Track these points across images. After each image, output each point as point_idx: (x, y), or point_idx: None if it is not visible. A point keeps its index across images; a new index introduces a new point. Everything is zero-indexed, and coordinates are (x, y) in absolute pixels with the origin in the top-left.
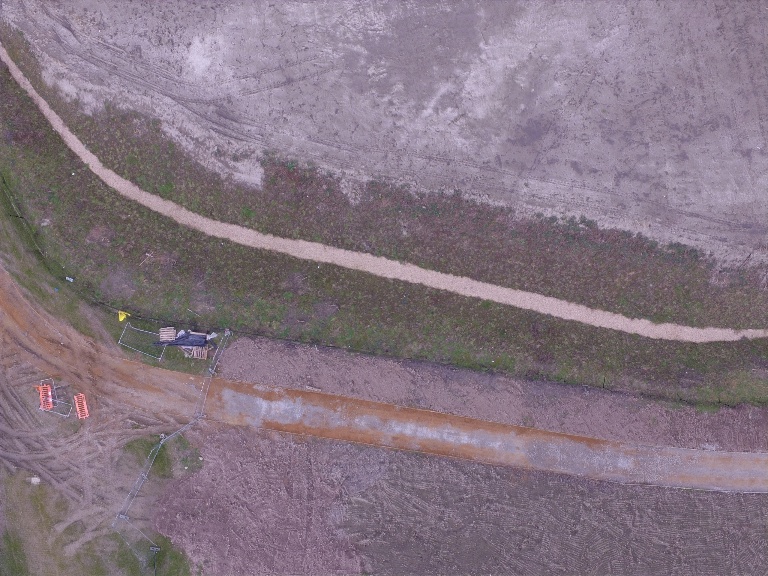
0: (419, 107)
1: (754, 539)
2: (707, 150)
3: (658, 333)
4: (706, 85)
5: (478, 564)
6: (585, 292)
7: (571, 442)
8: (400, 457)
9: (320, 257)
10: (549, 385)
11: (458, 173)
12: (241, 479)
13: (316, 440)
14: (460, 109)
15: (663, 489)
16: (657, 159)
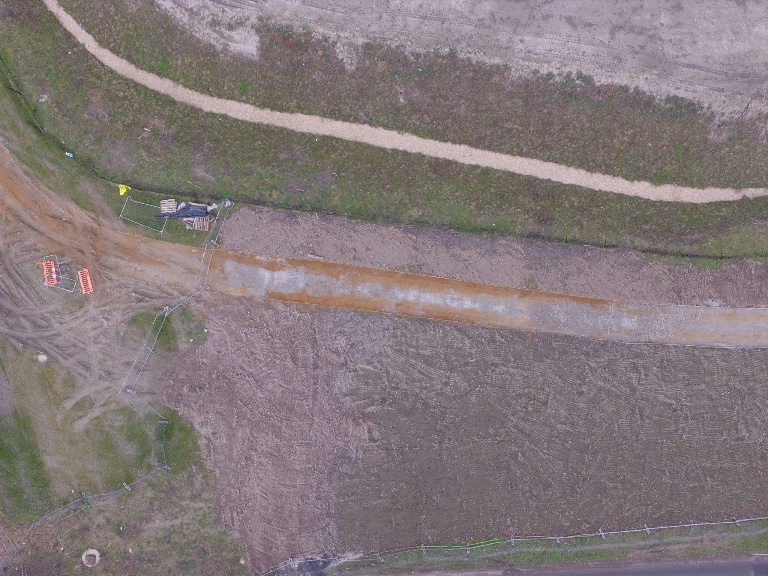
0: None
1: (760, 394)
2: None
3: (658, 195)
4: None
5: (485, 428)
6: (584, 155)
7: (574, 303)
8: (404, 323)
9: (318, 130)
10: (551, 247)
11: (453, 31)
12: (246, 350)
13: (320, 309)
14: None
15: (668, 347)
16: (652, 11)
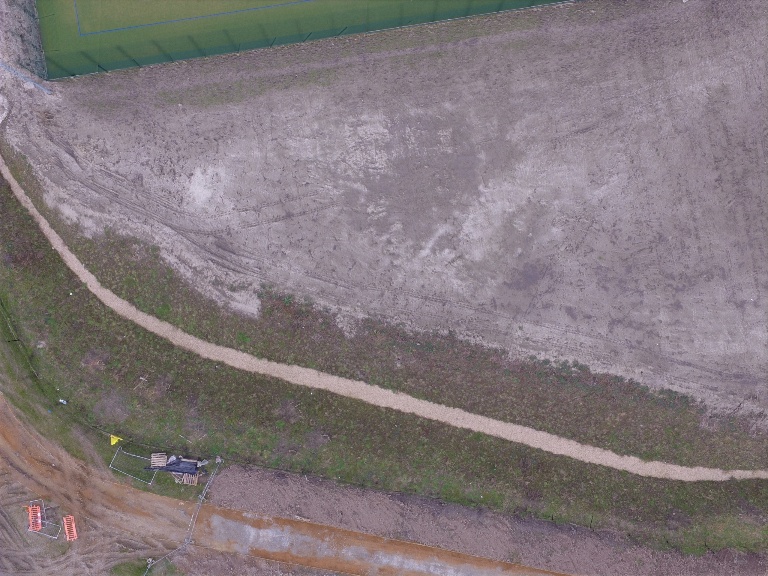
0: (417, 247)
1: None
2: (701, 300)
3: (647, 471)
4: (702, 236)
5: None
6: (576, 428)
7: None
8: None
9: (314, 383)
10: (537, 522)
11: (453, 314)
12: None
13: (303, 569)
14: (457, 250)
15: None
16: (651, 307)
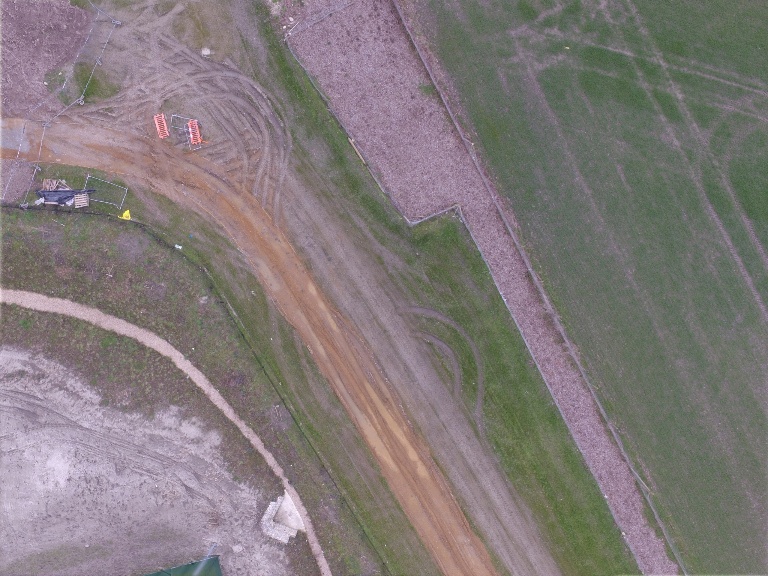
0: None
1: None
2: None
3: None
4: None
5: None
6: None
7: None
8: None
9: None
10: None
11: None
12: (7, 67)
13: None
14: None
15: None
16: None
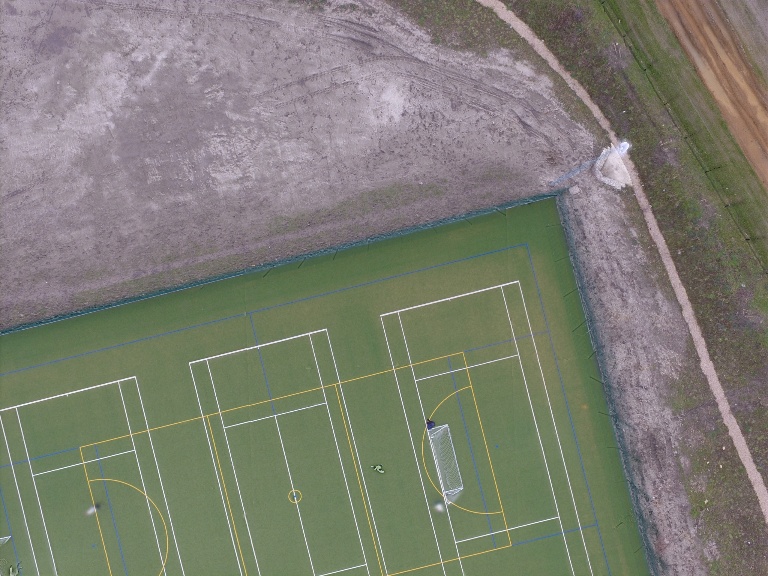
0: (170, 61)
1: None
2: None
3: None
4: None
5: None
6: None
7: None
8: None
9: None
10: None
11: None
12: None
13: None
14: (130, 61)
15: None
16: None
